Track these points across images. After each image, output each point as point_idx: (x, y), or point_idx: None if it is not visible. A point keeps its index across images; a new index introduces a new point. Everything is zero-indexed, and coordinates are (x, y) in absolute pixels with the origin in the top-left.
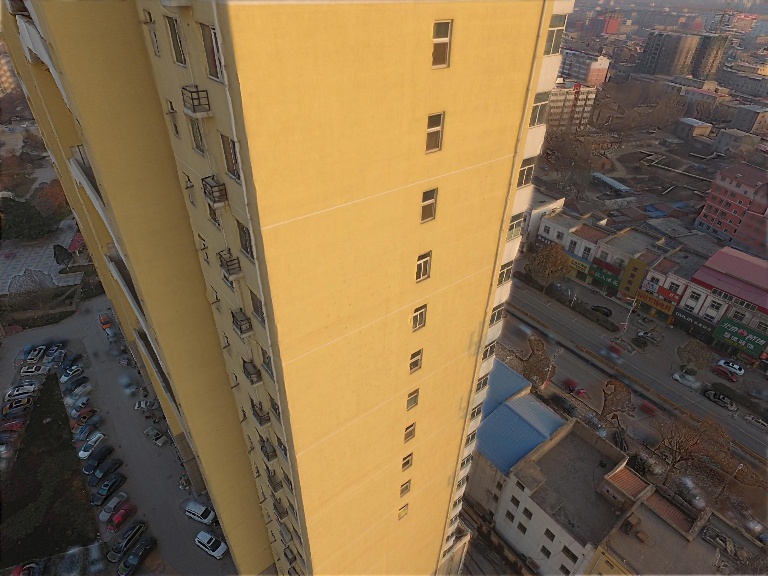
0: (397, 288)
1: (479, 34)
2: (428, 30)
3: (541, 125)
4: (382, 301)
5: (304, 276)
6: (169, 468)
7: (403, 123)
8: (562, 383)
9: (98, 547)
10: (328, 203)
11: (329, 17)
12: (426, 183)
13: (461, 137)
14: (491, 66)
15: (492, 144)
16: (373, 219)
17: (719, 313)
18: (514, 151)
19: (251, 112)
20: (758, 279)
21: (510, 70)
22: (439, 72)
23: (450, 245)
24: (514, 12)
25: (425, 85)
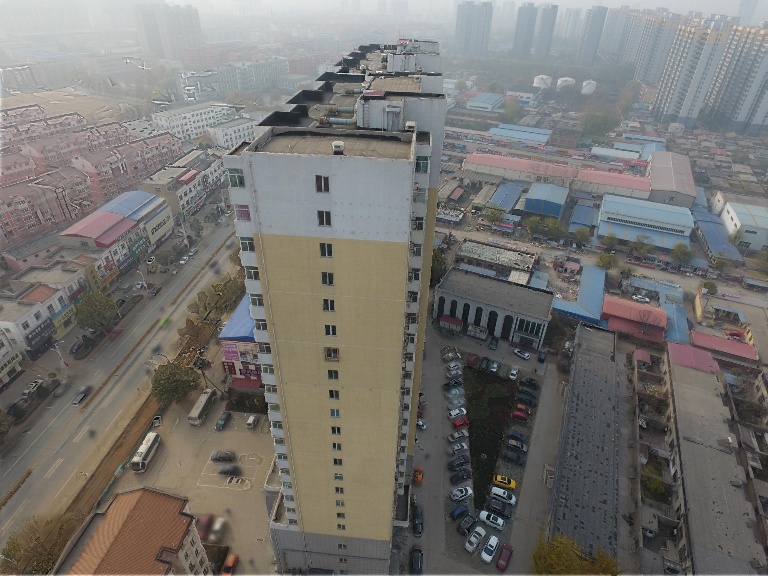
0: None
1: None
2: None
3: None
4: None
5: None
6: (422, 379)
7: None
8: (215, 299)
9: (464, 364)
10: None
11: None
12: None
13: None
14: None
15: None
16: None
17: (126, 248)
18: None
19: None
20: (108, 224)
21: None
22: None
23: None
24: None
25: None
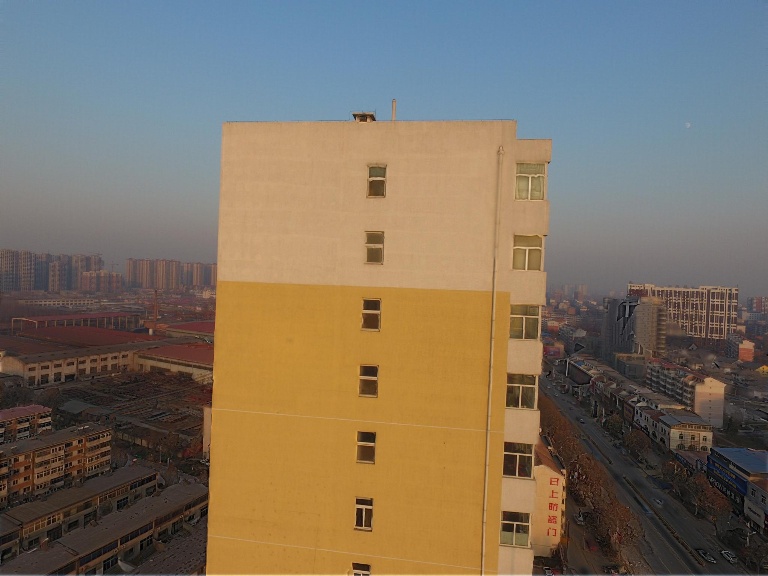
0: (329, 522)
1: (412, 311)
2: (357, 304)
3: (528, 409)
4: (311, 528)
5: (237, 460)
6: None
7: (334, 365)
8: None
9: None
10: (264, 408)
11: (275, 290)
12: (361, 423)
13: (401, 392)
14: (432, 337)
15: (447, 410)
16: (303, 437)
17: None
18: (486, 427)
19: (219, 334)
20: None
21: (459, 344)
22: (367, 333)
23: (399, 504)
24: (451, 298)
25: (356, 341)
